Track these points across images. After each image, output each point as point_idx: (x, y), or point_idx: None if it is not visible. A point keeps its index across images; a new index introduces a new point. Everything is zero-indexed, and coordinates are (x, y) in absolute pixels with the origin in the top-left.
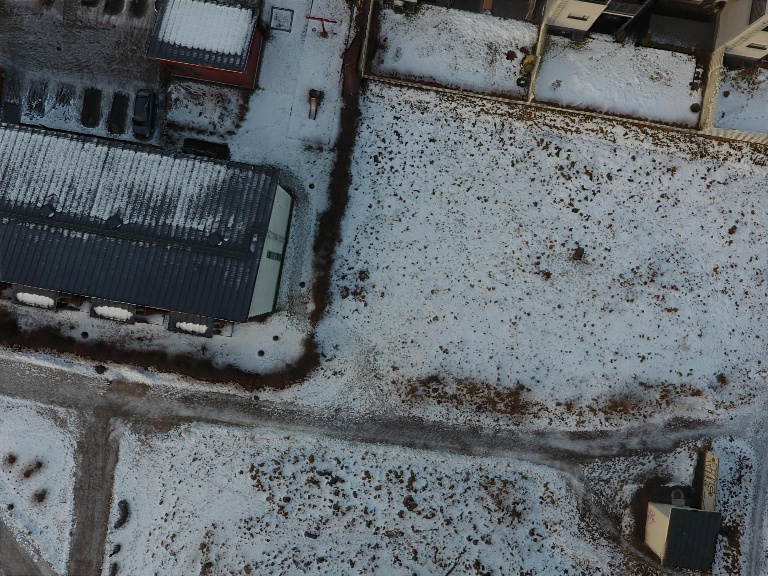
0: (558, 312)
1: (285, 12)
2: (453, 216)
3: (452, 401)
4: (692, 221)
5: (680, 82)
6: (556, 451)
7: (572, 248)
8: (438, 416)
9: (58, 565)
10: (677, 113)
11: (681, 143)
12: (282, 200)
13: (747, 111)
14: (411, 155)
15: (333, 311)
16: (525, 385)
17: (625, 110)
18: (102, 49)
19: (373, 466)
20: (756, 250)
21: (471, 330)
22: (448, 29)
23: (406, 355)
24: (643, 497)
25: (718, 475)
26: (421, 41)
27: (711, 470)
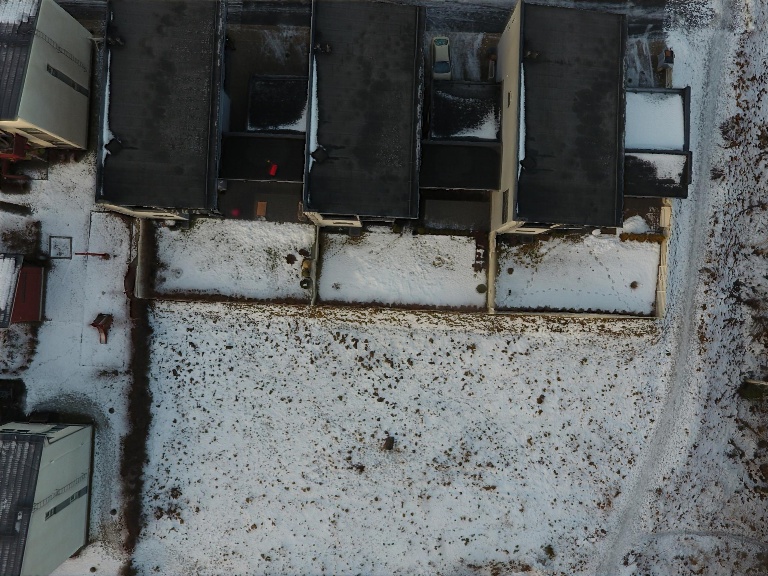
0: (376, 505)
1: (64, 240)
2: (259, 420)
3: None
4: (499, 395)
5: (462, 265)
6: None
7: (382, 438)
8: None
9: None
10: (464, 296)
11: (475, 322)
12: (66, 447)
13: (533, 285)
14: (209, 364)
15: (149, 533)
16: None
17: (411, 300)
18: None
19: None
20: (567, 416)
21: (291, 534)
22: (225, 240)
23: (229, 567)
24: None
25: None
26: (200, 255)
27: None
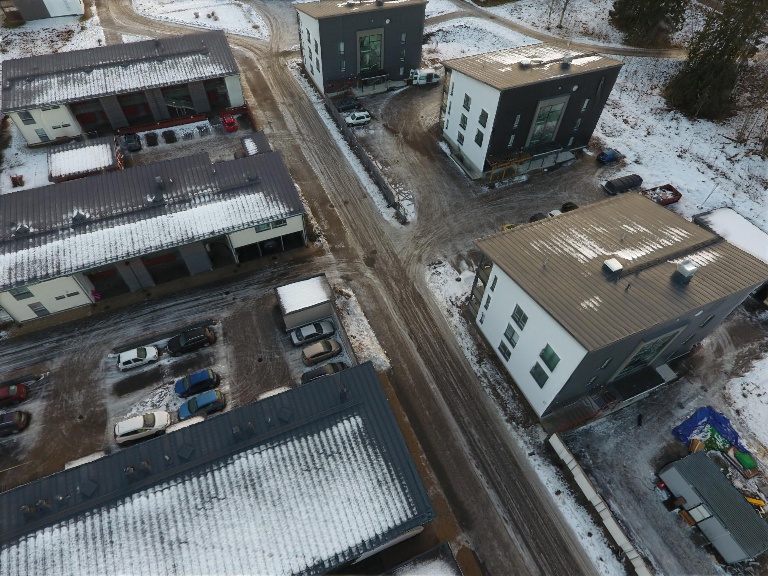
0: None
1: None
2: None
3: None
4: None
5: None
6: None
7: None
8: None
9: (126, 36)
10: None
11: None
12: None
13: None
14: None
15: None
16: None
17: None
18: (175, 157)
19: None
20: None
21: None
22: None
23: None
24: None
25: None
26: None
27: None
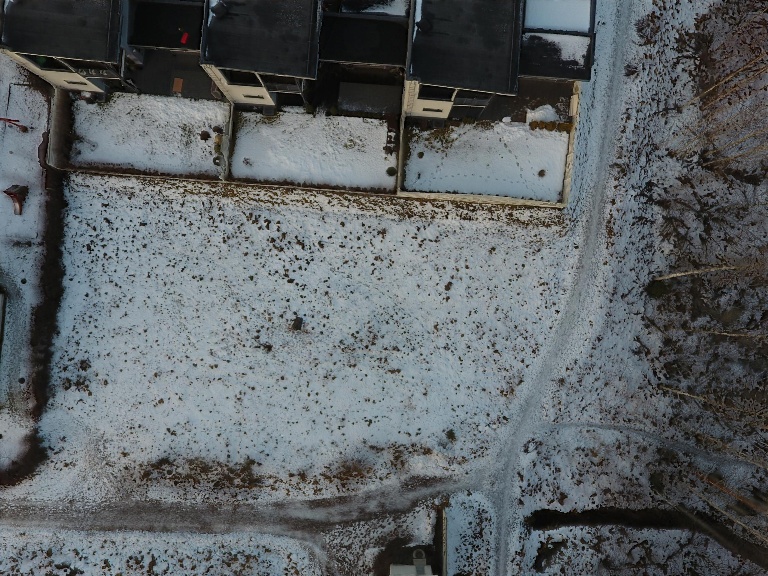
0: (282, 384)
1: None
2: (170, 297)
3: (189, 481)
4: (408, 281)
5: (374, 147)
6: (297, 521)
7: (291, 319)
8: (176, 497)
9: None
10: (374, 178)
11: (385, 206)
12: None
13: (442, 170)
14: (123, 240)
15: (57, 403)
16: (255, 460)
17: (322, 180)
18: None
19: (113, 554)
20: (474, 304)
21: (197, 410)
22: (140, 115)
23: (135, 440)
24: (385, 560)
25: (458, 531)
26: (115, 129)
27: (444, 529)
